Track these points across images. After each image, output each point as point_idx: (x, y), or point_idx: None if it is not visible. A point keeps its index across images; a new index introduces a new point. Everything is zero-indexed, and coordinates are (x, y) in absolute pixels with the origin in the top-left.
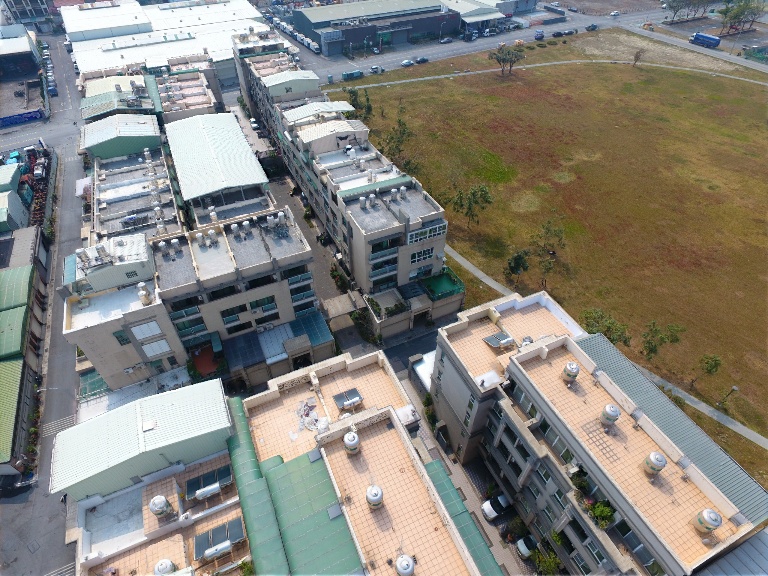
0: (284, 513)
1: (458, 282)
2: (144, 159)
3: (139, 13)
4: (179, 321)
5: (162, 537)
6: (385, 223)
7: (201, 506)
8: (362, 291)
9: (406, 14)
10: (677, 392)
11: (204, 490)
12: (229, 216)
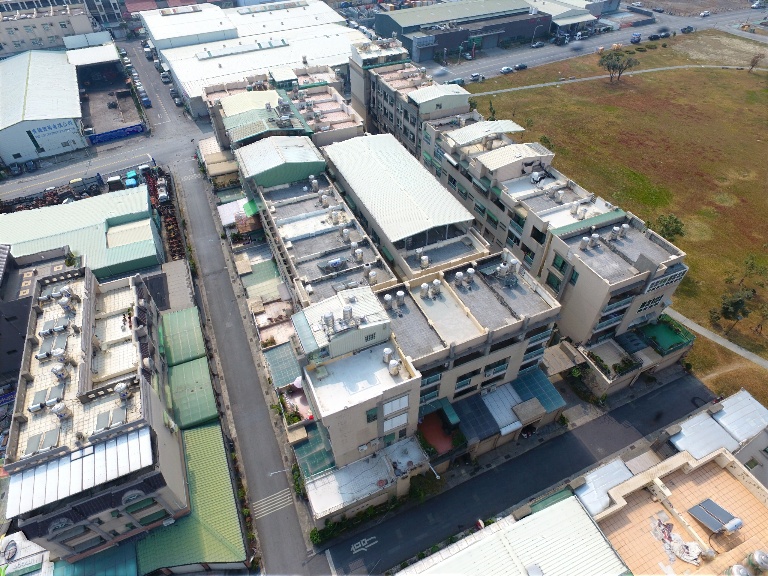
0: None
1: (682, 332)
2: (308, 187)
3: (223, 18)
4: None
5: None
6: (618, 269)
7: None
8: (578, 343)
9: (494, 17)
10: None
11: None
12: (435, 259)
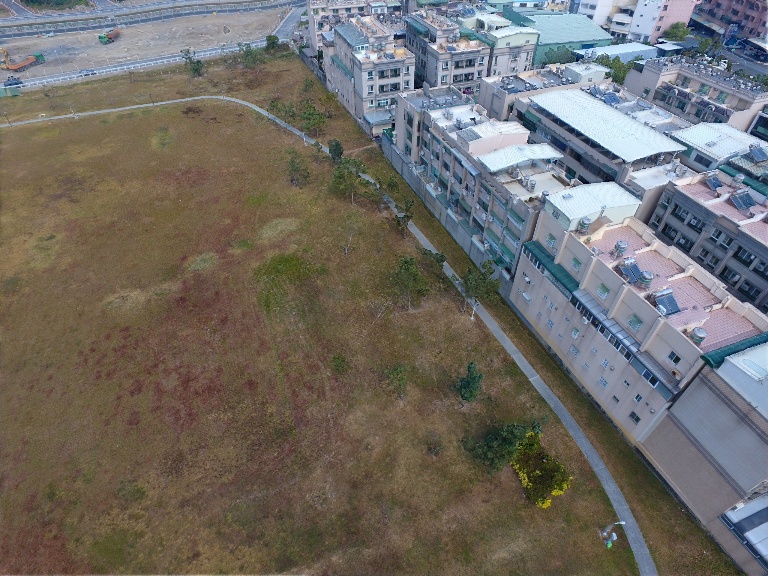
0: None
1: None
2: None
3: None
4: None
5: None
6: (438, 97)
7: None
8: None
9: None
10: (285, 124)
11: None
12: None
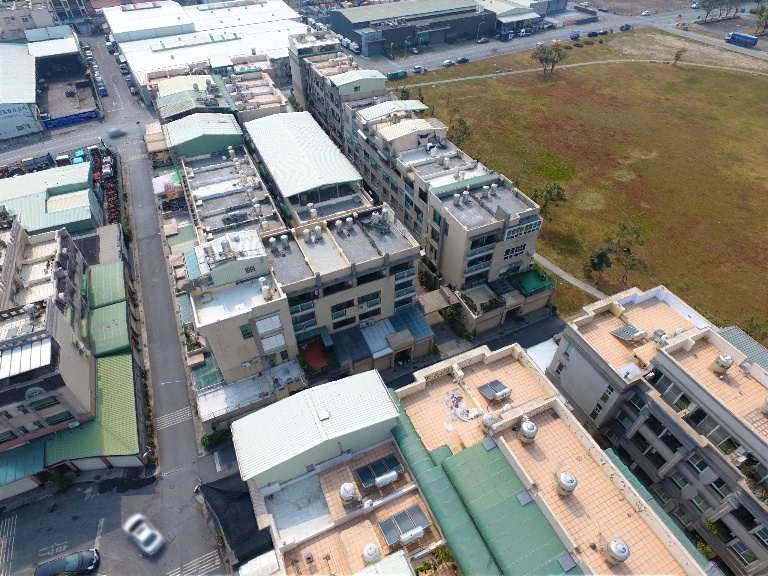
0: (473, 500)
1: (547, 278)
2: (227, 157)
3: (181, 14)
4: (294, 316)
5: (346, 524)
6: (482, 219)
7: (376, 494)
8: (454, 287)
9: (442, 14)
10: None
11: (383, 478)
12: (326, 213)
